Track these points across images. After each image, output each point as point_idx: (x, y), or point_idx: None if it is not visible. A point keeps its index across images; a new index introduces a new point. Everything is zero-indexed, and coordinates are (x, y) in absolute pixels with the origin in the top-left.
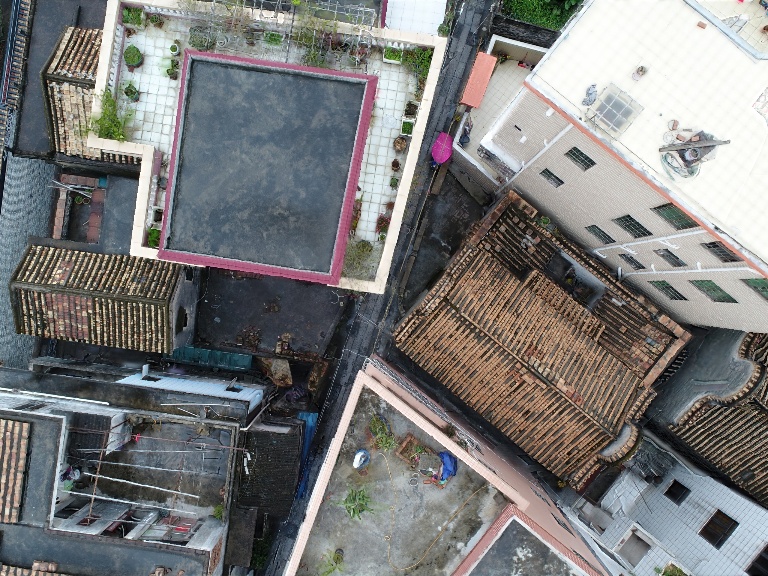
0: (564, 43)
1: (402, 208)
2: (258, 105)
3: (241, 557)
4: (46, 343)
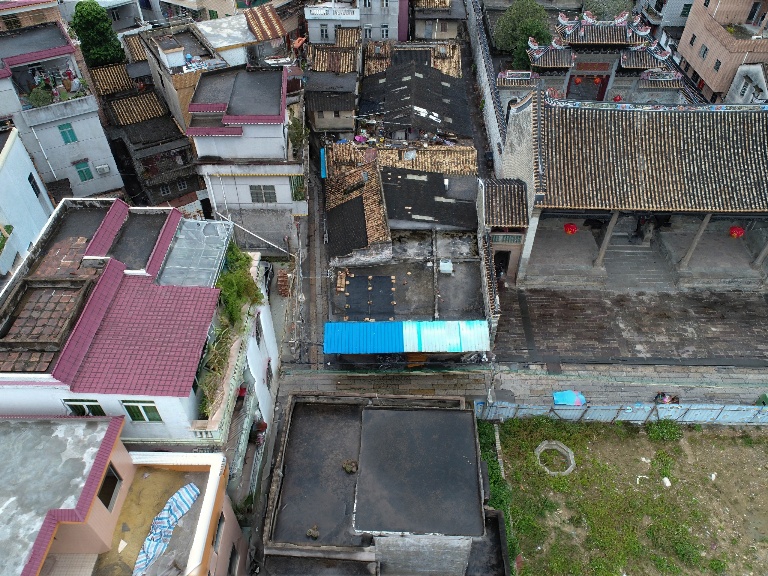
0: None
1: None
2: None
3: None
4: (463, 22)
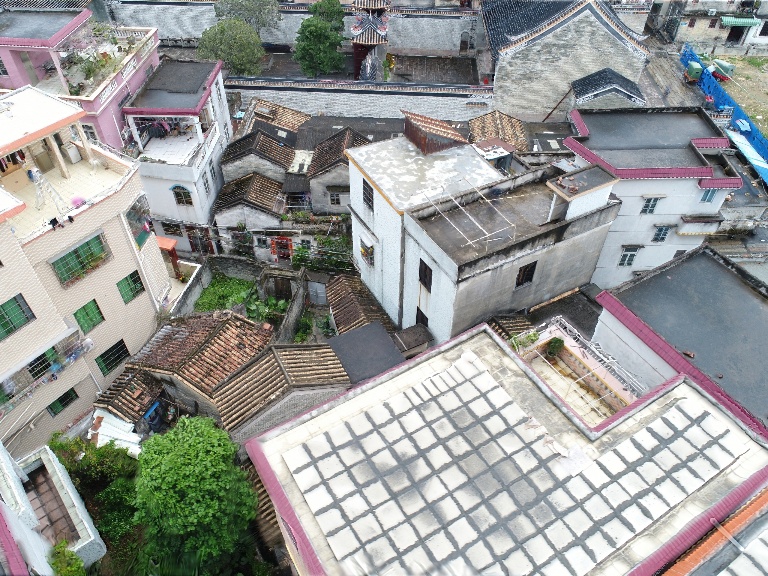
0: (43, 95)
1: (5, 91)
2: (57, 24)
3: None
4: None
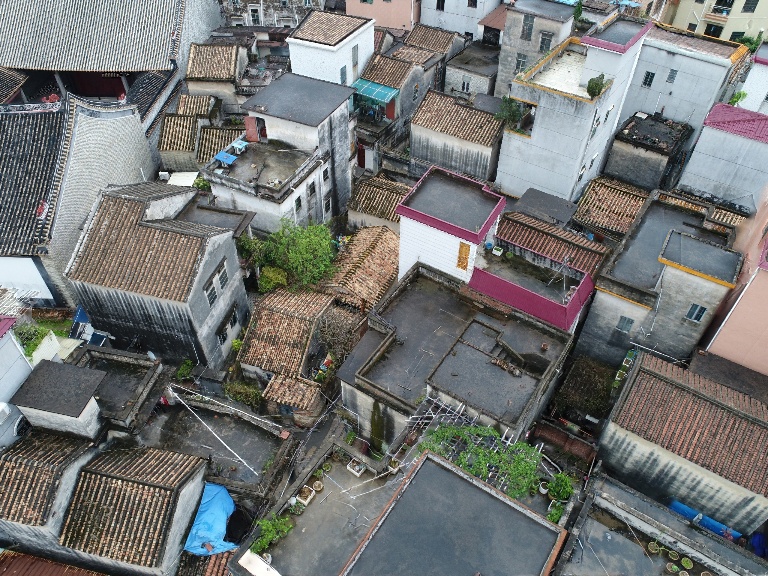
0: None
1: None
2: None
3: (331, 5)
4: None
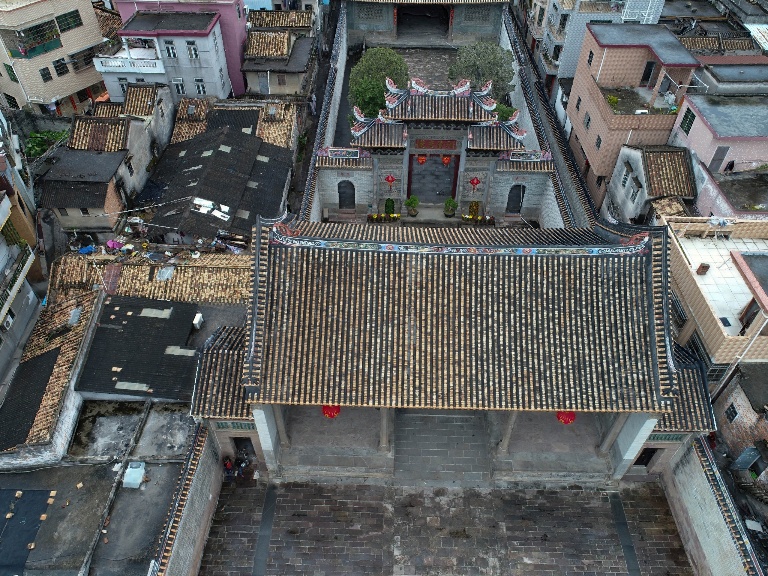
0: None
1: None
2: None
3: None
4: None
